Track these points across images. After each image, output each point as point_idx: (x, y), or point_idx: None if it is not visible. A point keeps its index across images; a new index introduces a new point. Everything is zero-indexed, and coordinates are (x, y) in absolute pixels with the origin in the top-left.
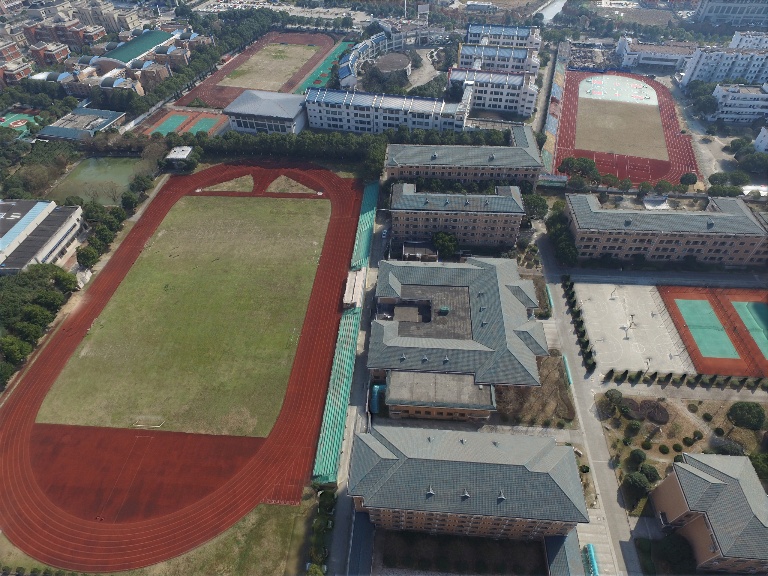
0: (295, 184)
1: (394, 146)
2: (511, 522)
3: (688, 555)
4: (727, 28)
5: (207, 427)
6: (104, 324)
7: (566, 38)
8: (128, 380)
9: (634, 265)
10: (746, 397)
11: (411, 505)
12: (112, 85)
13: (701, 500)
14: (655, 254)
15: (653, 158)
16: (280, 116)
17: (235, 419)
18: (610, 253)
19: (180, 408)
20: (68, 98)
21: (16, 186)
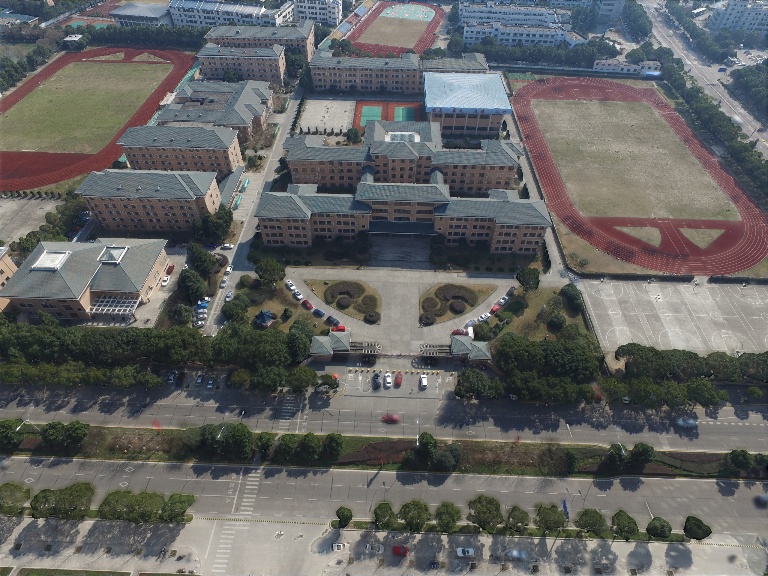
0: (153, 57)
1: (215, 27)
2: (201, 160)
3: (288, 176)
4: None
5: (62, 150)
6: (7, 116)
7: None
8: (19, 135)
9: (349, 92)
10: None
11: (145, 144)
12: None
13: (288, 144)
14: (362, 86)
15: (403, 47)
16: (149, 16)
17: (79, 148)
18: (336, 85)
19: (48, 144)
20: None
21: None
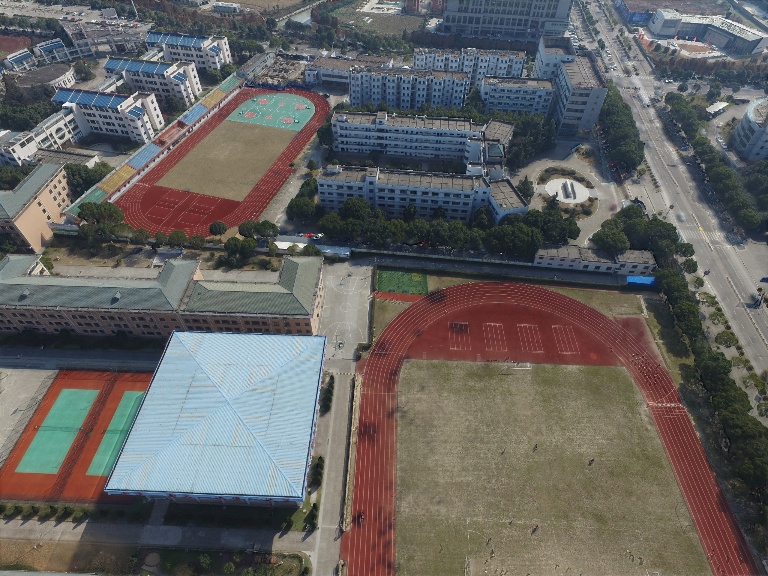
0: None
1: None
2: None
3: None
4: (455, 40)
5: None
6: None
7: (278, 48)
8: None
9: (59, 342)
10: (7, 531)
11: None
12: None
13: None
14: (85, 329)
15: (227, 198)
16: None
17: None
18: (35, 327)
19: None
20: None
21: None
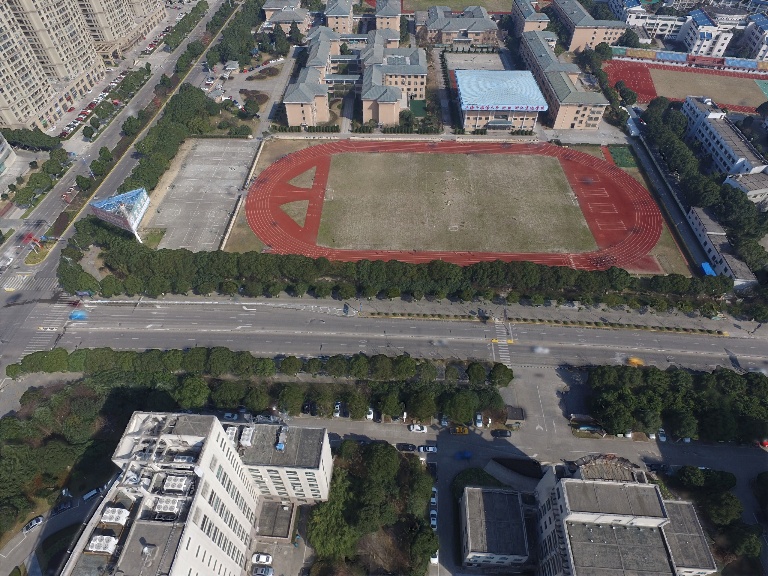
0: (545, 4)
1: None
2: None
3: None
4: None
5: (405, 3)
6: None
7: None
8: None
9: None
10: None
11: None
12: None
13: None
14: None
15: (657, 91)
16: None
17: None
18: None
19: None
20: None
21: None
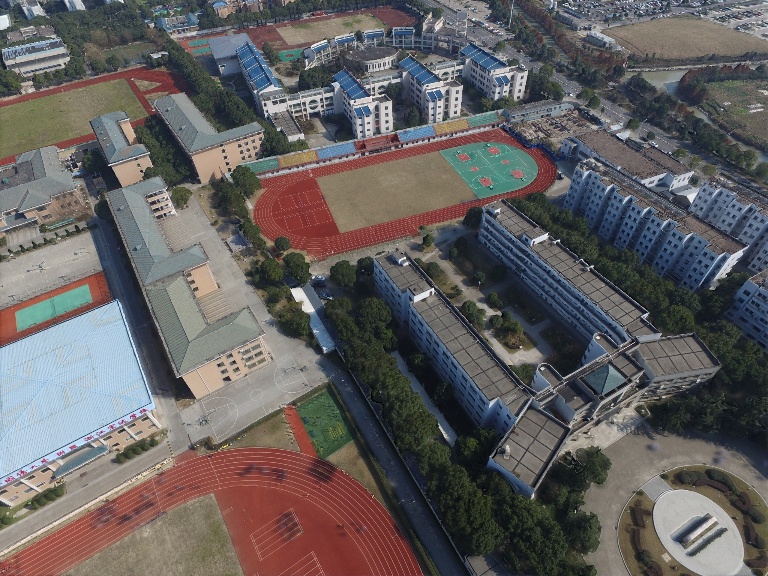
0: None
1: None
2: None
3: None
4: None
5: None
6: None
7: None
8: None
9: None
10: None
11: None
12: (213, 5)
13: None
14: None
15: (337, 222)
16: (214, 54)
17: None
18: None
19: None
20: (193, 6)
21: (83, 38)
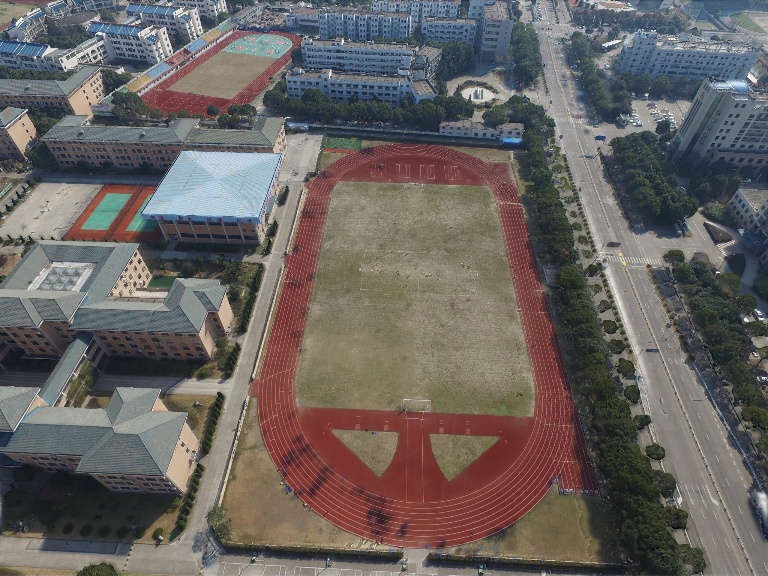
0: None
1: None
2: None
3: None
4: None
5: None
6: None
7: (266, 3)
8: None
9: (103, 171)
10: None
11: None
12: None
13: None
14: (120, 162)
15: (221, 97)
16: None
17: None
18: (86, 161)
19: None
20: None
21: None
